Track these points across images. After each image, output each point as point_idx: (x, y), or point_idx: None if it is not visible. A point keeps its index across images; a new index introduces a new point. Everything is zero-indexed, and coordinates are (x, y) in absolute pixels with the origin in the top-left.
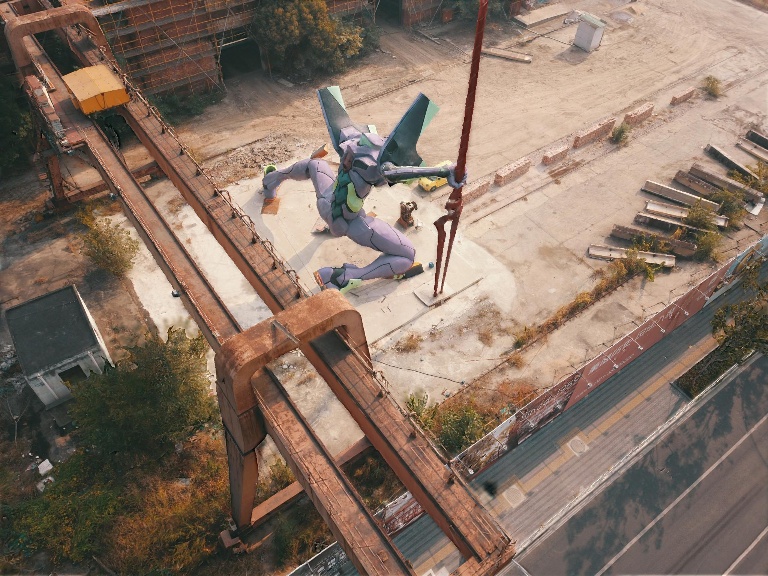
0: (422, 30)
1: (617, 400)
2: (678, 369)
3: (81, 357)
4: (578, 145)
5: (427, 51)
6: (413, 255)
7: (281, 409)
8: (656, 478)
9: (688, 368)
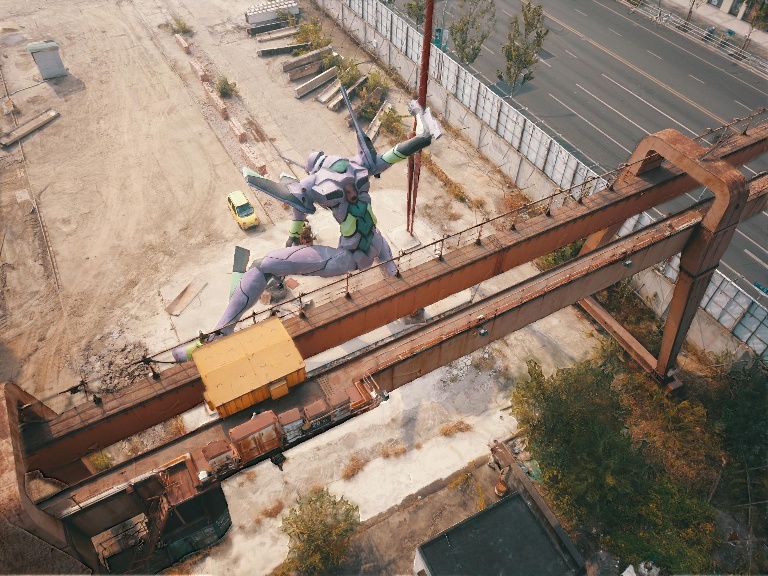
0: None
1: None
2: None
3: None
4: (227, 115)
5: None
6: None
7: None
8: None
9: None
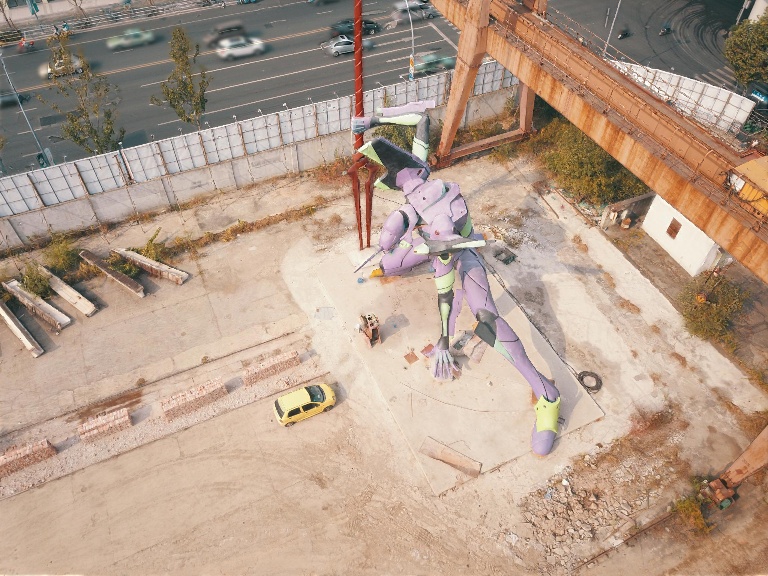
0: None
1: None
2: None
3: None
4: None
5: None
6: None
7: (511, 3)
8: None
9: None
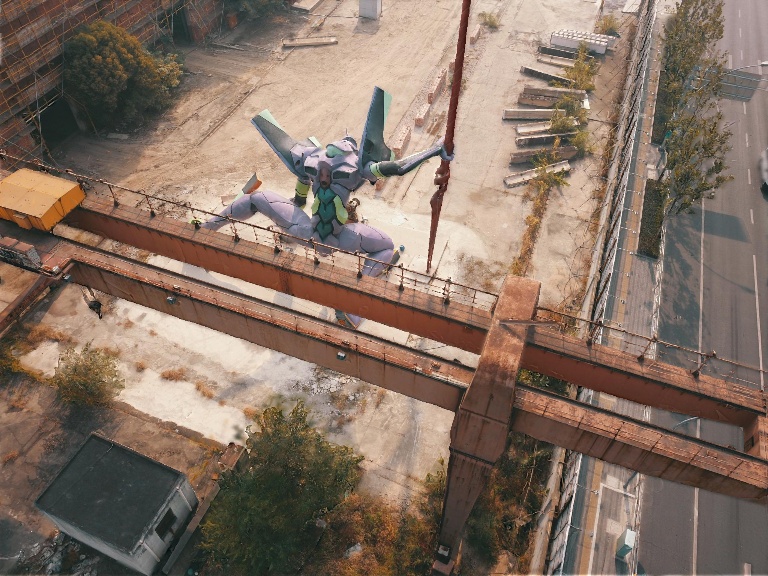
0: (216, 42)
1: (614, 285)
2: (632, 242)
3: (171, 497)
4: (432, 101)
5: (237, 60)
6: (392, 244)
7: (533, 398)
8: (678, 326)
9: (637, 238)
